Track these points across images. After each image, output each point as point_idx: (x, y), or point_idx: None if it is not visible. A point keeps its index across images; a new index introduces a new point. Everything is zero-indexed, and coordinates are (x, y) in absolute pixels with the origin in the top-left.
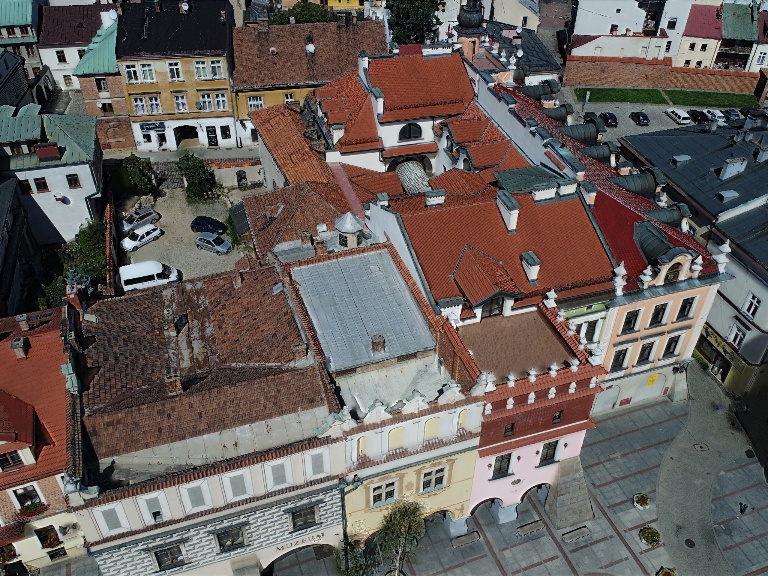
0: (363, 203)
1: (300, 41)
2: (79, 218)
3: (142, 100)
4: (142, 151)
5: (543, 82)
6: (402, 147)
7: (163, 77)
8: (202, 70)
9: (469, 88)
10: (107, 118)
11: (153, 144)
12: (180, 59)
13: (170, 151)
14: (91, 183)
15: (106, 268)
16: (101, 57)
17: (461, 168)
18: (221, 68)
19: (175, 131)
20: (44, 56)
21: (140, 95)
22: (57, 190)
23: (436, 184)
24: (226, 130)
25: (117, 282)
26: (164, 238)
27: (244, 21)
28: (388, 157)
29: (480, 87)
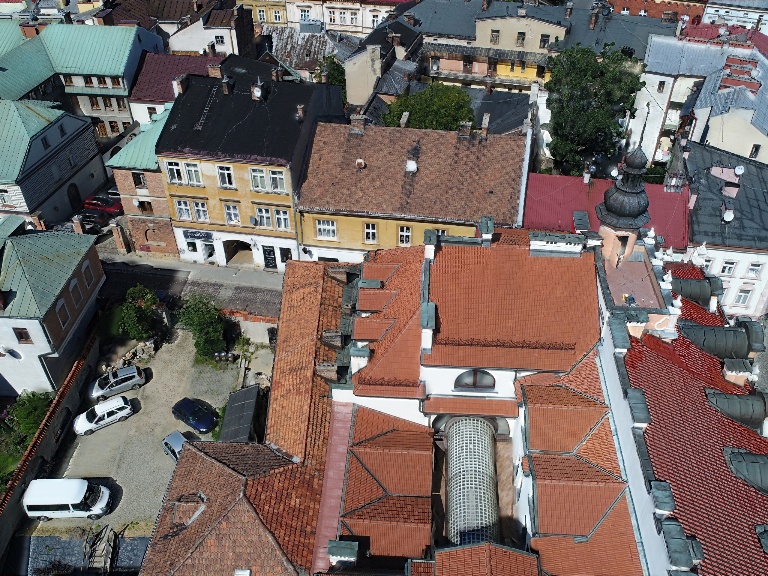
0: (344, 518)
1: (401, 153)
2: (34, 375)
3: (187, 203)
4: (186, 260)
5: (739, 321)
6: (459, 398)
7: (211, 181)
8: (260, 179)
9: (593, 324)
10: (146, 218)
11: (199, 254)
12: (232, 163)
13: (217, 266)
14: (45, 340)
15: (3, 487)
16: (143, 146)
17: (530, 492)
18: (284, 180)
19: (226, 244)
20: (135, 111)
21: (184, 198)
22: (4, 342)
23: (444, 568)
24: (288, 252)
25: (21, 502)
26: (134, 420)
27: (374, 91)
28: (431, 412)
29: (605, 340)
